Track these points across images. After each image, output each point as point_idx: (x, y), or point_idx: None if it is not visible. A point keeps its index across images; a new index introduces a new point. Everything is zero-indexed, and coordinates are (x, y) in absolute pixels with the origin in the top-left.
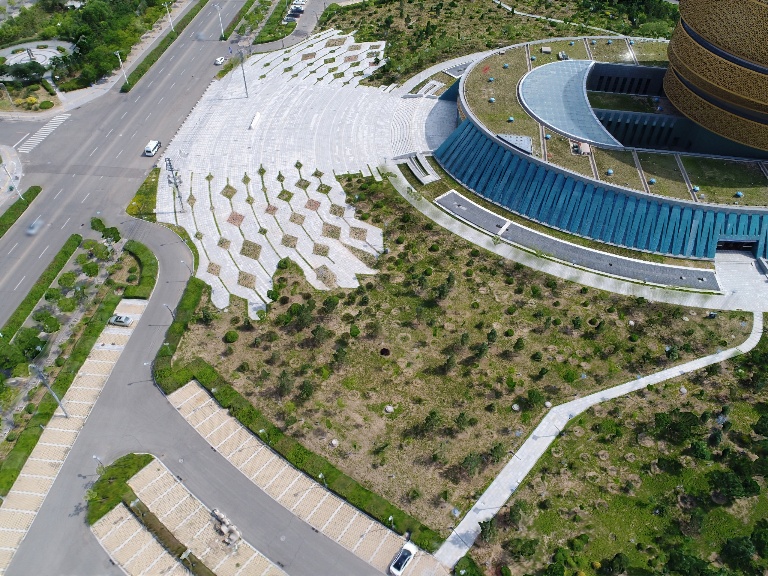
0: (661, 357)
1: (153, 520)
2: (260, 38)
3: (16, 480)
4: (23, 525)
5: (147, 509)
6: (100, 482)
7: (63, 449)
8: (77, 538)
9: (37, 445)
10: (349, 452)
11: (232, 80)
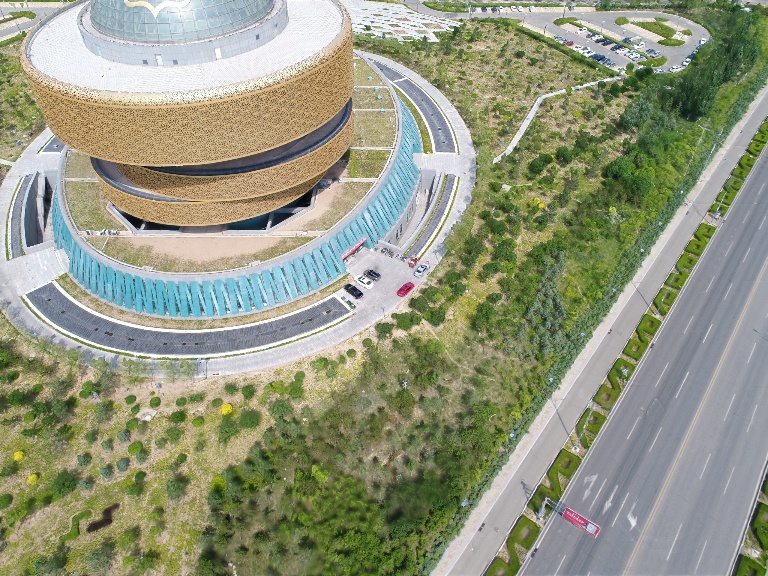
0: (1, 123)
1: (1, 21)
2: (432, 3)
3: (38, 2)
4: (18, 6)
5: (7, 20)
6: (25, 11)
7: (48, 6)
8: (6, 13)
9: (53, 2)
10: (5, 49)
11: (359, 3)
